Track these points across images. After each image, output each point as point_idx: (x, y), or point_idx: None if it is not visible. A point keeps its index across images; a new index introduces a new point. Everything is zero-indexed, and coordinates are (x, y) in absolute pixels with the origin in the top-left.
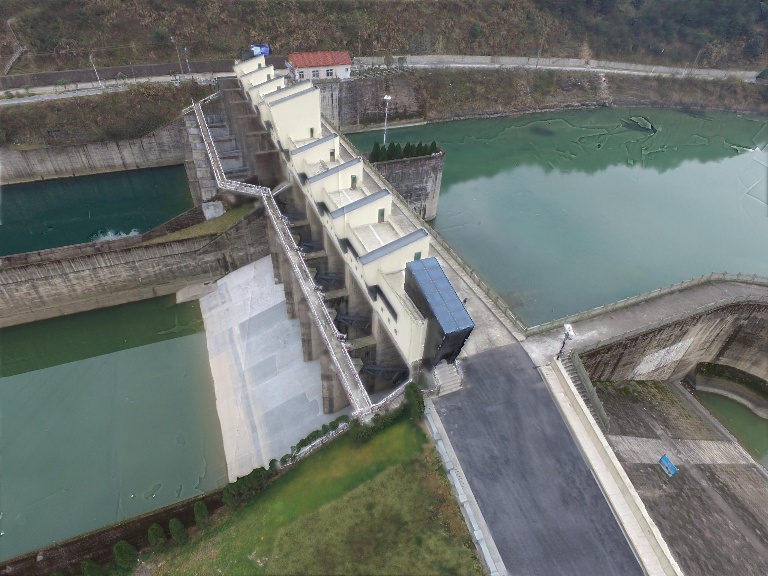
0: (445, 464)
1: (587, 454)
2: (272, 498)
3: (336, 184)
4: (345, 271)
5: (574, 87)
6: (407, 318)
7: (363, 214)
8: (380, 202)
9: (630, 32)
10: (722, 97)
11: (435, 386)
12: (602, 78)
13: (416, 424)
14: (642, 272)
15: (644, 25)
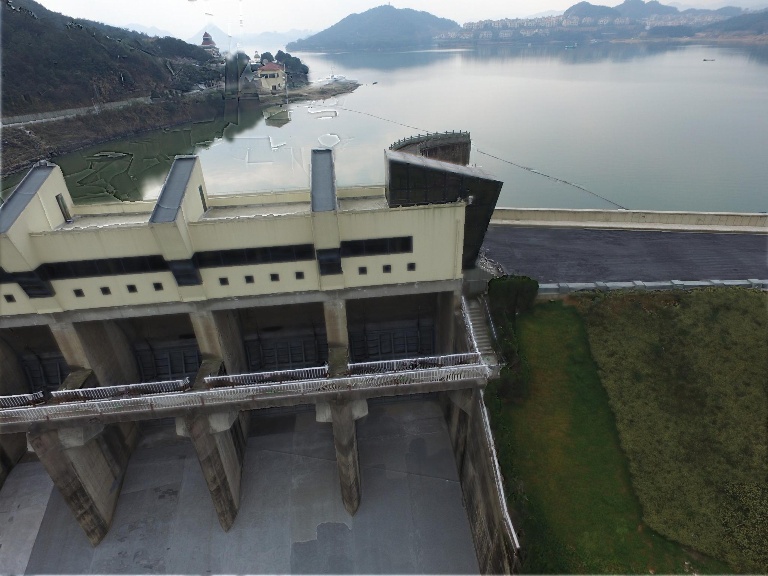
0: (600, 286)
1: (571, 225)
2: (569, 559)
3: (43, 220)
4: (195, 328)
5: (4, 147)
6: (442, 216)
7: (191, 201)
8: (196, 174)
9: (8, 83)
10: (142, 119)
11: (489, 275)
12: (25, 131)
13: (533, 305)
14: None
15: (16, 74)
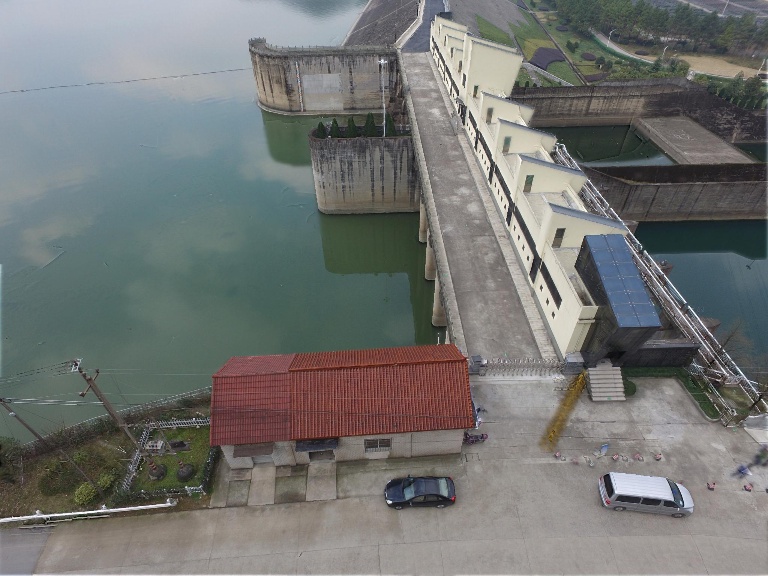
0: None
1: None
2: None
3: None
4: None
5: None
6: None
7: None
8: None
9: None
10: None
11: None
12: None
13: None
14: (217, 144)
15: None
